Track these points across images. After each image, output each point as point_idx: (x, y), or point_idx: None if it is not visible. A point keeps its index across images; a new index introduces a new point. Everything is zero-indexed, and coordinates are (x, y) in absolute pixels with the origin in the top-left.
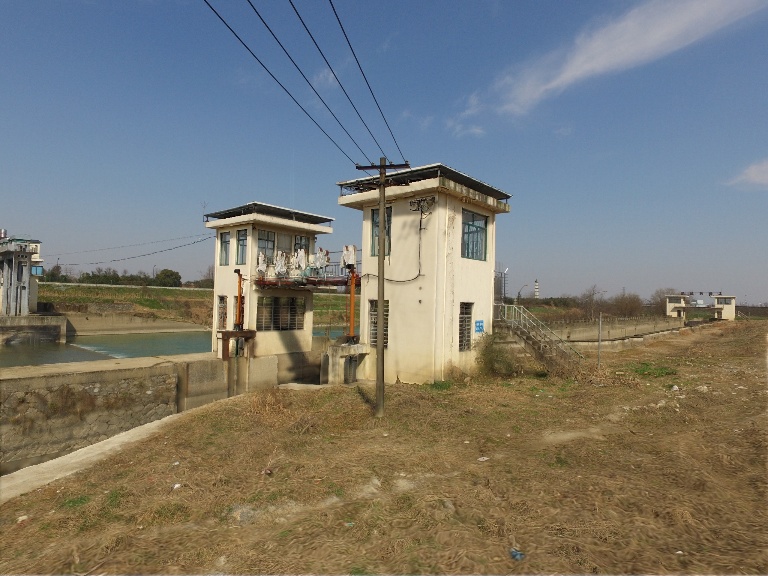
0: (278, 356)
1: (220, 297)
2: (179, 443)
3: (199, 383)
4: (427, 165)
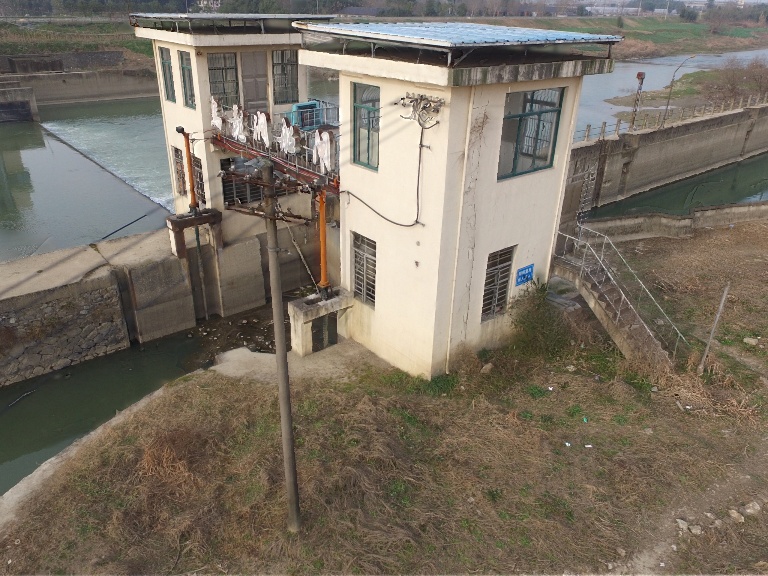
0: (262, 236)
1: (175, 147)
2: (23, 569)
3: (150, 291)
4: (428, 39)
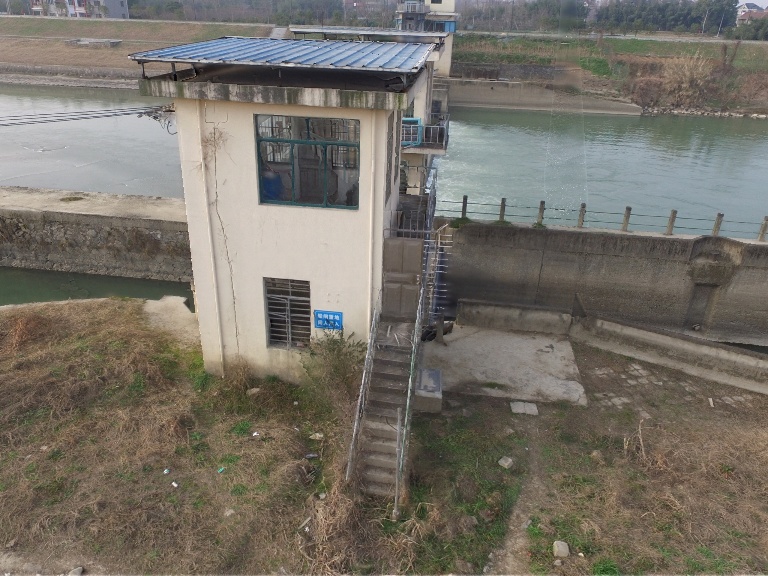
0: None
1: None
2: None
3: None
4: (142, 52)
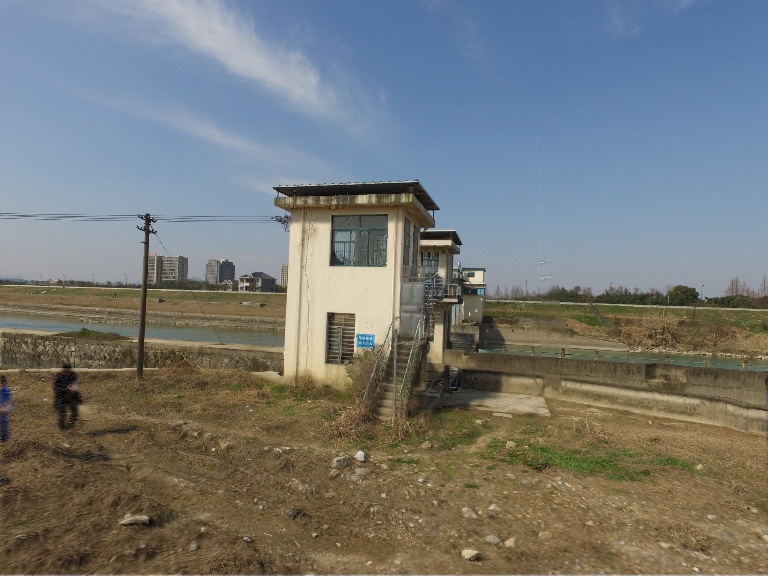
0: None
1: None
2: None
3: None
4: None
